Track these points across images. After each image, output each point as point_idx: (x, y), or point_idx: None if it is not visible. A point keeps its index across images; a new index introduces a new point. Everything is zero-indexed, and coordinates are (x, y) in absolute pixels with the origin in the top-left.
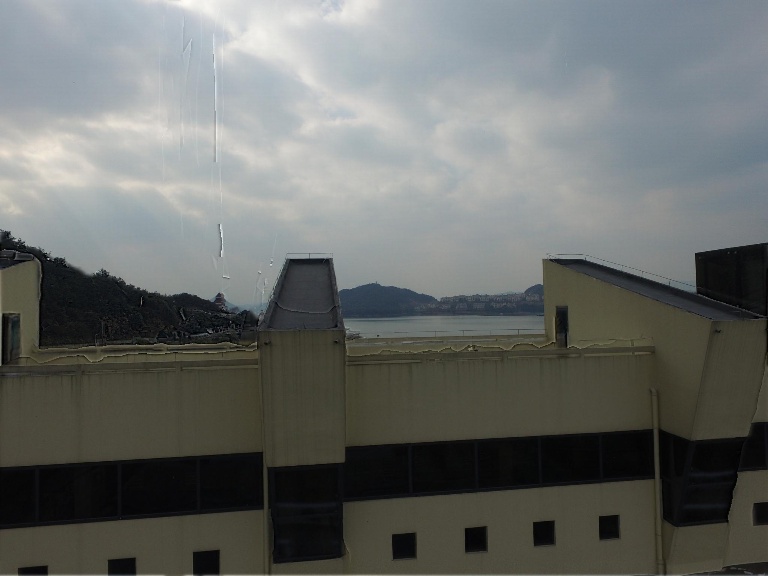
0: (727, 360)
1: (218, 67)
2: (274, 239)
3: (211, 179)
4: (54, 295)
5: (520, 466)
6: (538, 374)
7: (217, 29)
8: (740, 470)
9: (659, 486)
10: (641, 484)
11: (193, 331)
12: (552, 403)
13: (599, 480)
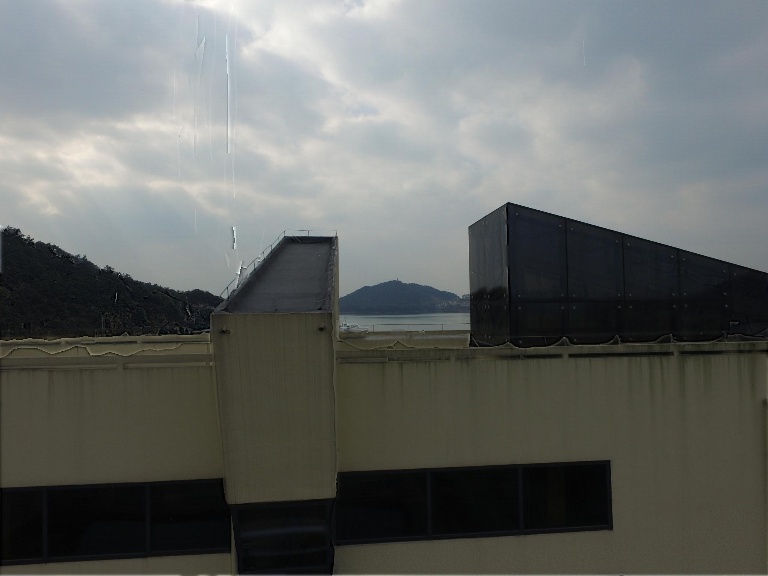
0: (259, 378)
1: (231, 65)
2: (261, 234)
3: (224, 176)
4: (56, 291)
5: (20, 530)
6: (45, 394)
7: (230, 27)
8: (383, 540)
9: (235, 565)
10: (212, 560)
11: (198, 327)
12: (68, 437)
13: (144, 553)
